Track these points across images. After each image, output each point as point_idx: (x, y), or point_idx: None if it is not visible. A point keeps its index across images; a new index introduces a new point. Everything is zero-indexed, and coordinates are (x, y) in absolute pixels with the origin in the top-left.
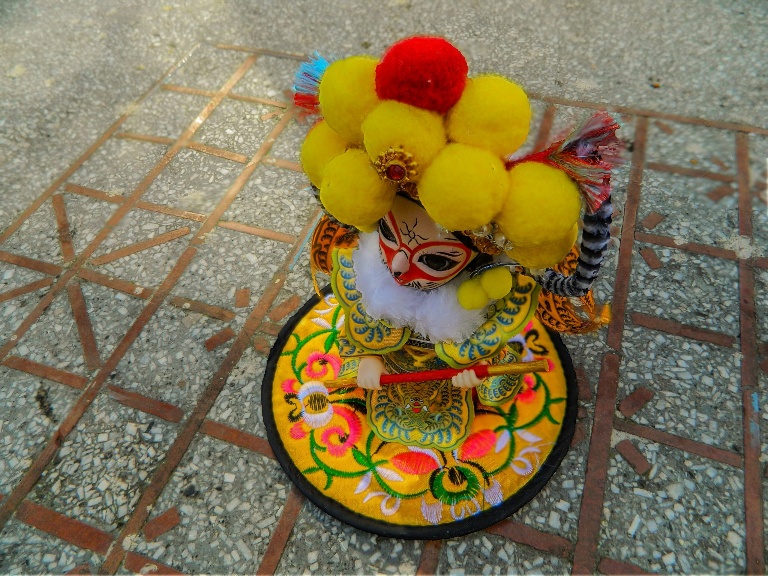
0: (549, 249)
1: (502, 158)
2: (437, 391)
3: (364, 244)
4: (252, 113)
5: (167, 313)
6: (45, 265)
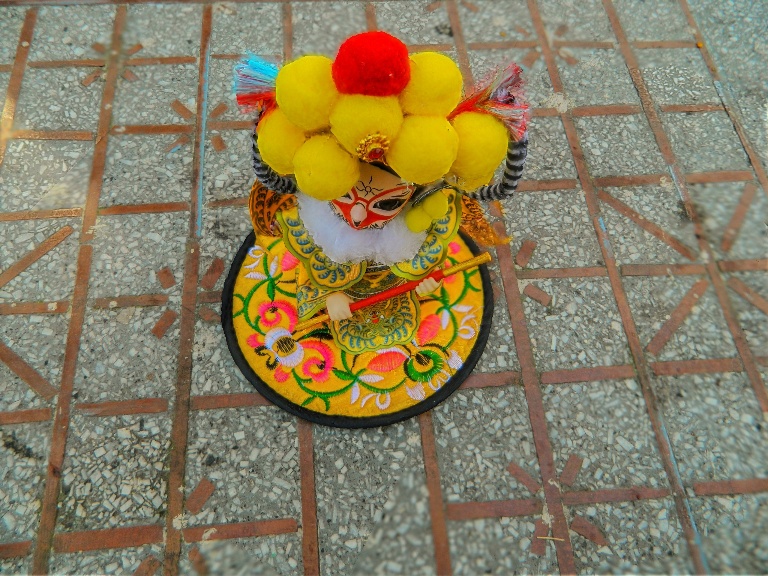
0: None
1: (446, 117)
2: (390, 300)
3: (305, 202)
4: (69, 80)
5: (97, 318)
6: None
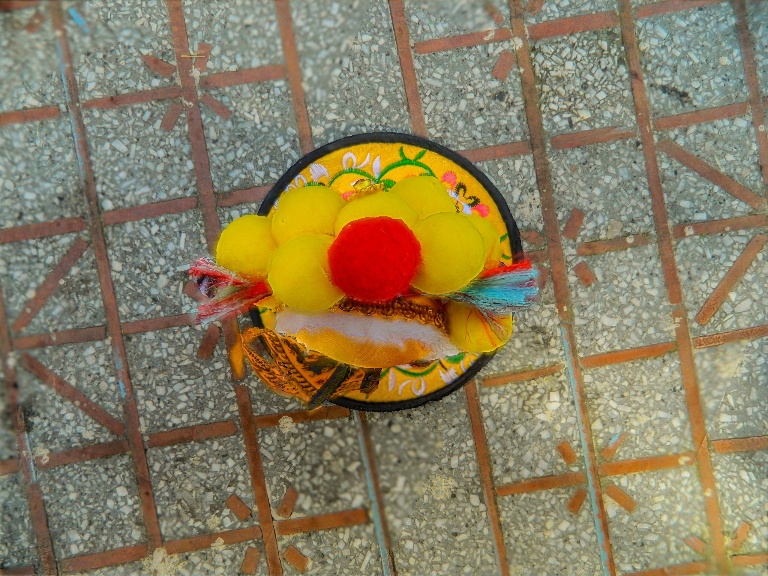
0: None
1: None
2: None
3: None
4: (766, 528)
5: (642, 223)
6: None
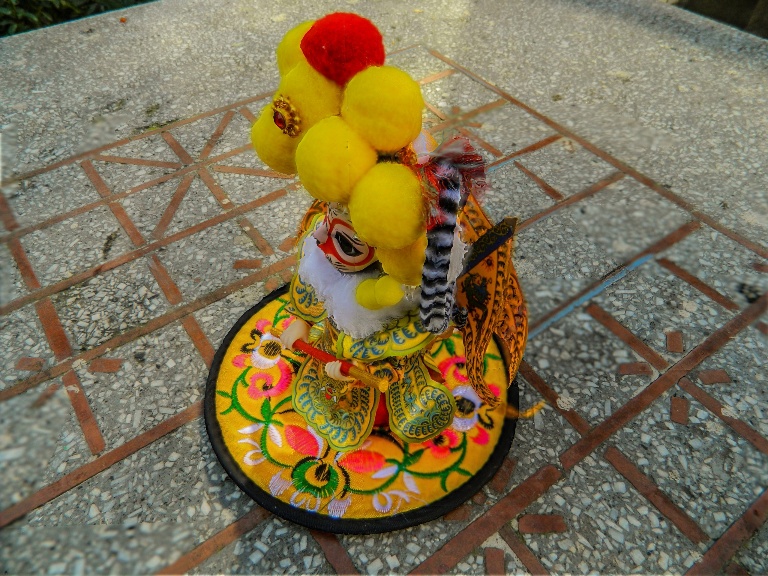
0: (398, 260)
1: (376, 148)
2: None
3: None
4: None
5: (230, 227)
6: (185, 154)
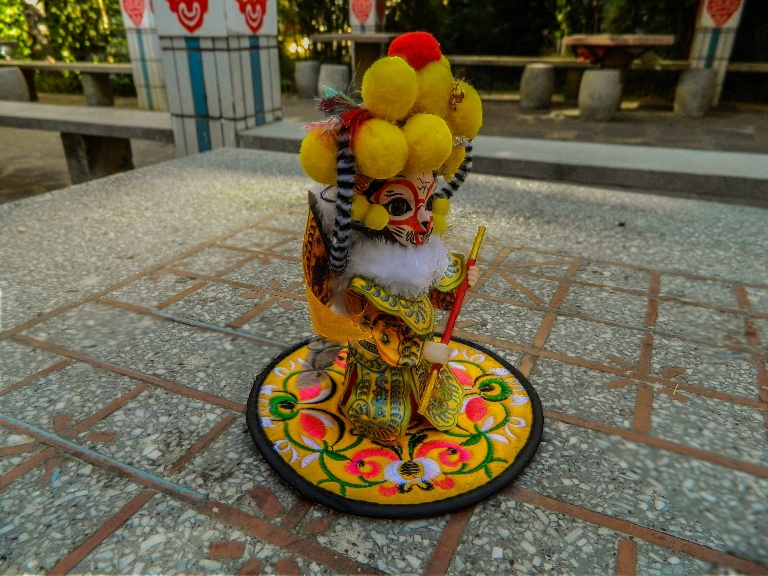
0: None
1: None
2: None
3: (362, 264)
4: None
5: None
6: None
